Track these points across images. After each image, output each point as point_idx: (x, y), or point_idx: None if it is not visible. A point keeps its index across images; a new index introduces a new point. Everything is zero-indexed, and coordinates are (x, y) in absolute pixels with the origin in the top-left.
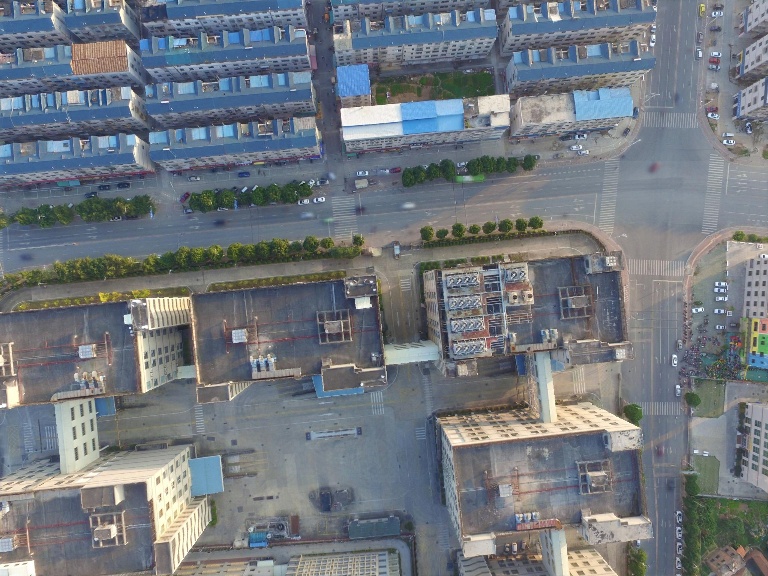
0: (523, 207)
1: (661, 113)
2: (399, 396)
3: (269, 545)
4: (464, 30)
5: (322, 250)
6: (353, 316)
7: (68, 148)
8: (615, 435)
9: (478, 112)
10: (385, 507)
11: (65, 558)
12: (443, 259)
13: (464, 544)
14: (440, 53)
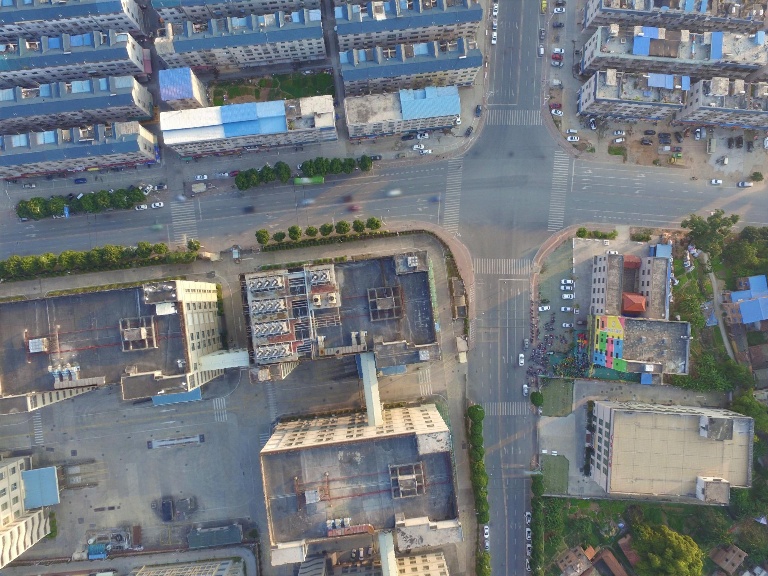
0: (365, 208)
1: (504, 111)
2: (242, 402)
3: (109, 557)
4: (287, 31)
5: (161, 256)
6: (158, 322)
7: None
8: (422, 438)
9: (300, 113)
10: (229, 515)
11: None
12: (285, 262)
13: (271, 552)
14: (273, 55)
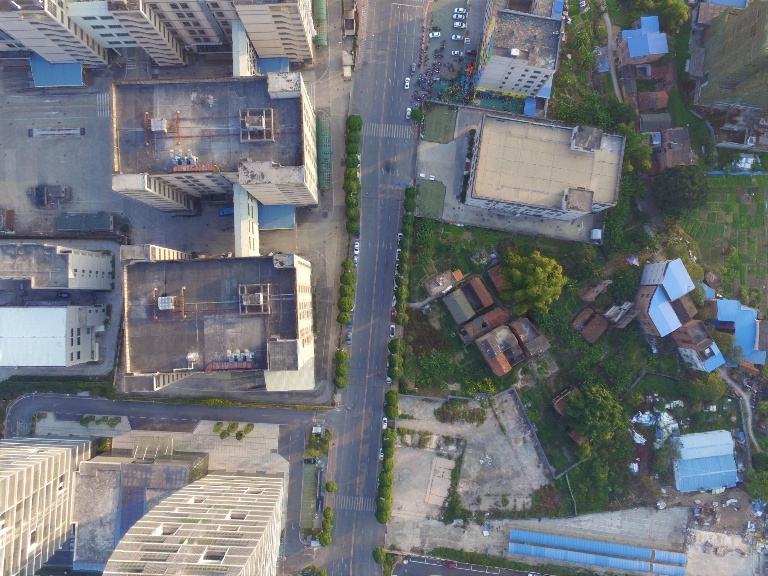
0: None
1: None
2: None
3: None
4: None
5: None
6: None
7: None
8: (272, 76)
9: None
10: (103, 208)
11: None
12: None
13: (113, 176)
14: None
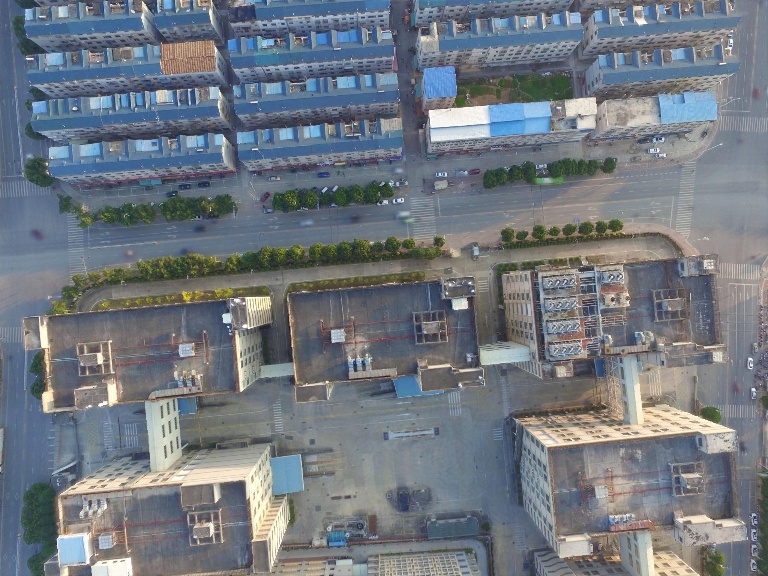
0: (600, 209)
1: (738, 117)
2: (476, 397)
3: (348, 544)
4: (551, 33)
5: (401, 251)
6: (448, 317)
7: (156, 147)
8: (710, 437)
9: (565, 115)
10: (462, 507)
11: (161, 555)
12: (521, 261)
13: (559, 545)
14: (522, 55)
